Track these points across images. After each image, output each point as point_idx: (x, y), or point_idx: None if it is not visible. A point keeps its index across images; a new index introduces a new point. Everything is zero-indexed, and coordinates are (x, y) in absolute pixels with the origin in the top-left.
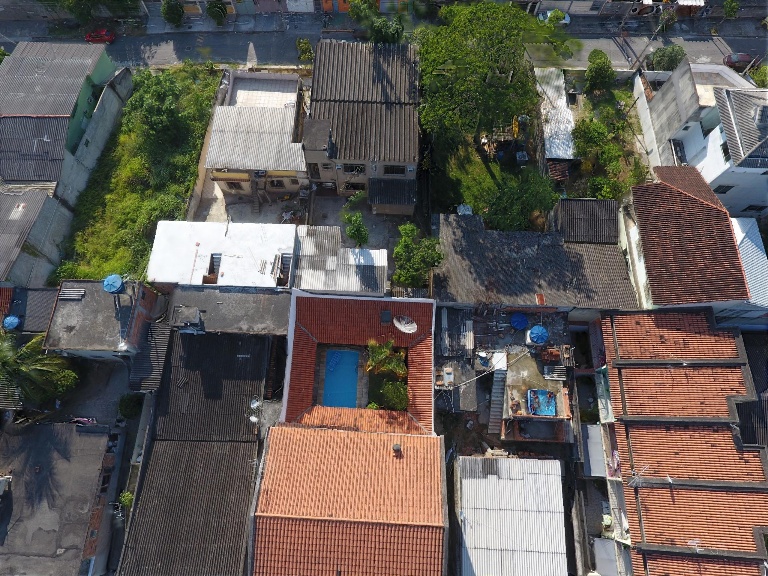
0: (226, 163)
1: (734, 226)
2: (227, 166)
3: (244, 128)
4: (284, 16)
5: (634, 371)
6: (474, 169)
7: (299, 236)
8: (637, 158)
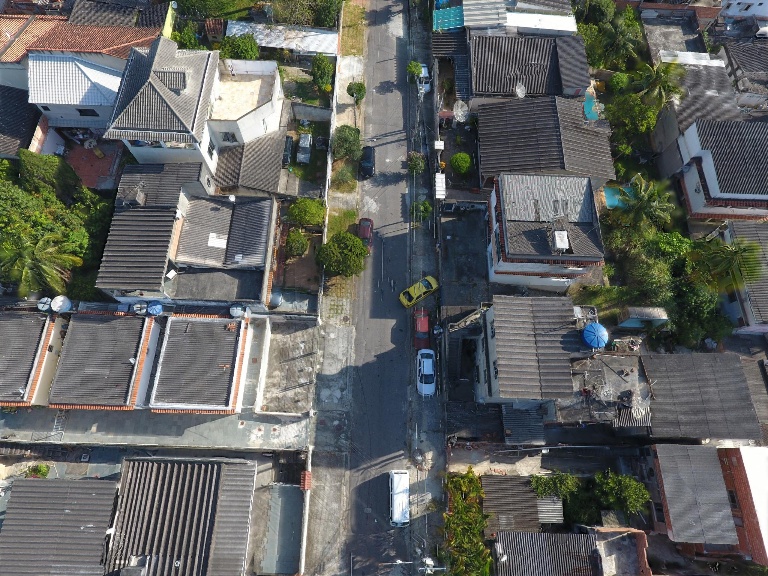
0: None
1: (106, 83)
2: None
3: None
4: None
5: (22, 24)
6: (244, 2)
7: None
8: None
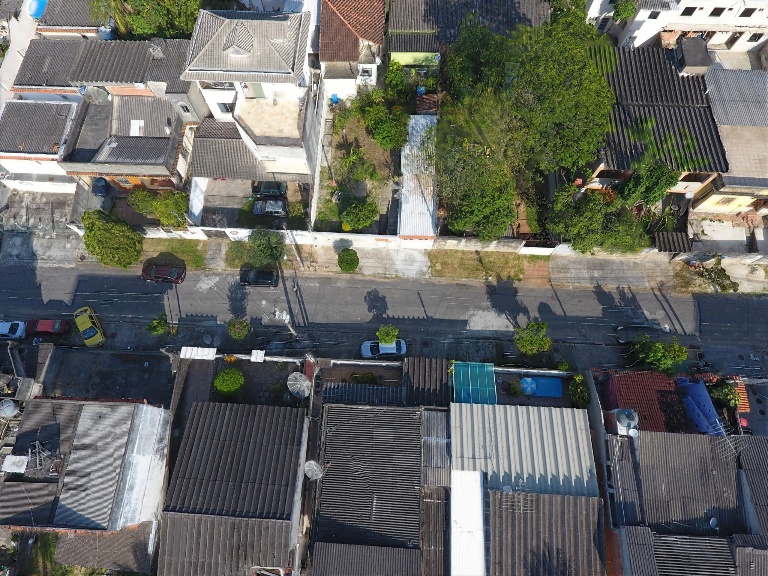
0: (766, 75)
1: None
2: (764, 72)
3: (765, 106)
4: (766, 377)
5: None
6: None
7: (676, 2)
8: (349, 113)
